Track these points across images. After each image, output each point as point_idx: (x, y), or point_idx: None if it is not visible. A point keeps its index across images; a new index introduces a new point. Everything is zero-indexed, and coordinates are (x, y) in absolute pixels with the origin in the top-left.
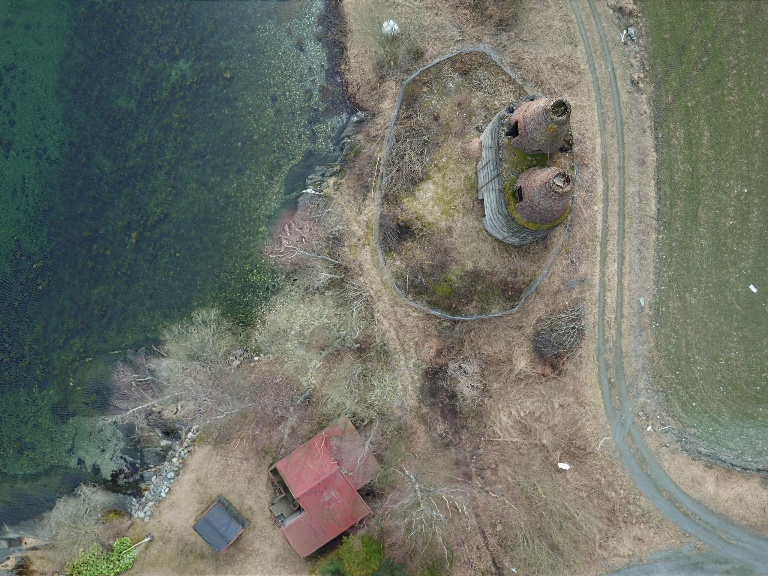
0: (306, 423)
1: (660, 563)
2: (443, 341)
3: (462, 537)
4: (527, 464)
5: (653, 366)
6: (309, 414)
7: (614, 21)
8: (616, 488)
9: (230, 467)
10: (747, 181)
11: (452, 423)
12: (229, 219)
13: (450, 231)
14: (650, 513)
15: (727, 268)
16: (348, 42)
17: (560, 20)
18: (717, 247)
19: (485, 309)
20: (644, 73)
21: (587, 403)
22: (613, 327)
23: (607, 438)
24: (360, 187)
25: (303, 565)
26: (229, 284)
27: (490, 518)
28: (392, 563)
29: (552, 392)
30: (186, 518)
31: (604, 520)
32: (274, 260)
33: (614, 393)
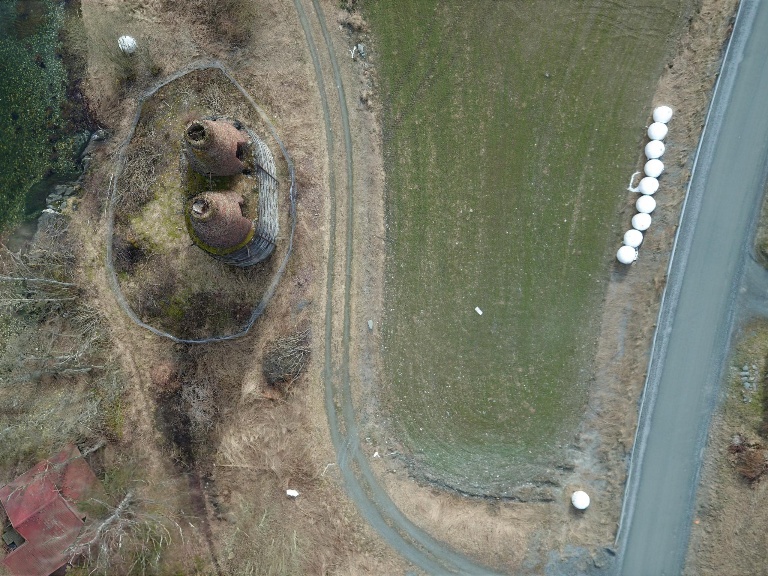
0: (40, 449)
1: None
2: (178, 364)
3: (195, 565)
4: (258, 491)
5: (381, 390)
6: (44, 440)
7: (344, 37)
8: (341, 515)
9: None
10: (472, 201)
11: (186, 448)
12: None
13: (176, 252)
14: (374, 541)
15: (453, 290)
16: (89, 58)
17: (290, 36)
18: (444, 268)
19: (217, 332)
20: (373, 90)
21: (312, 428)
22: (340, 350)
23: (332, 464)
24: (96, 207)
25: None
26: None
27: (222, 546)
28: None
29: (281, 417)
30: None
31: (331, 548)
32: None
33: (340, 418)
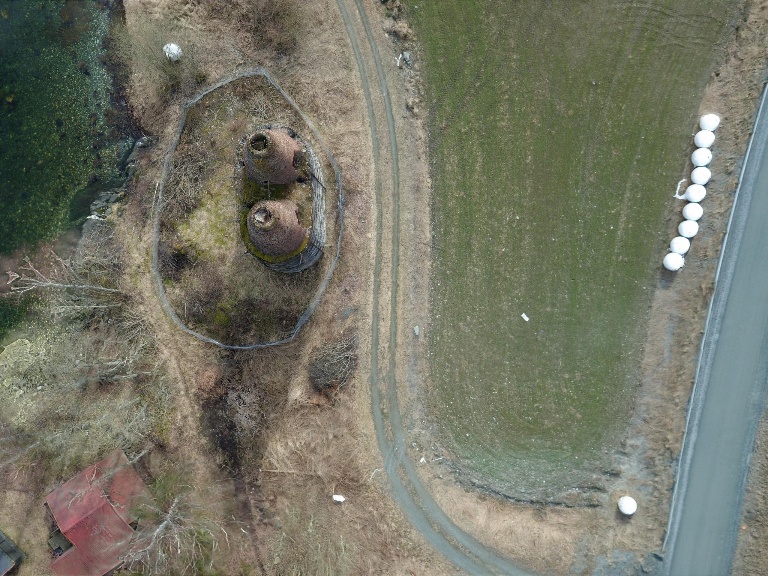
0: (86, 454)
1: None
2: (223, 370)
3: (240, 570)
4: (304, 496)
5: (427, 396)
6: (89, 445)
7: (389, 45)
8: (388, 521)
9: (8, 499)
10: (519, 208)
11: (232, 454)
12: (14, 246)
13: (223, 259)
14: (421, 546)
15: (500, 296)
16: (133, 65)
17: (336, 44)
18: (490, 275)
19: (263, 338)
20: (419, 98)
21: (359, 434)
22: (387, 356)
23: (379, 470)
24: (141, 213)
25: None
26: (14, 312)
27: (268, 551)
28: None
29: (327, 423)
30: None
31: (378, 553)
32: (1, 294)
33: (387, 424)
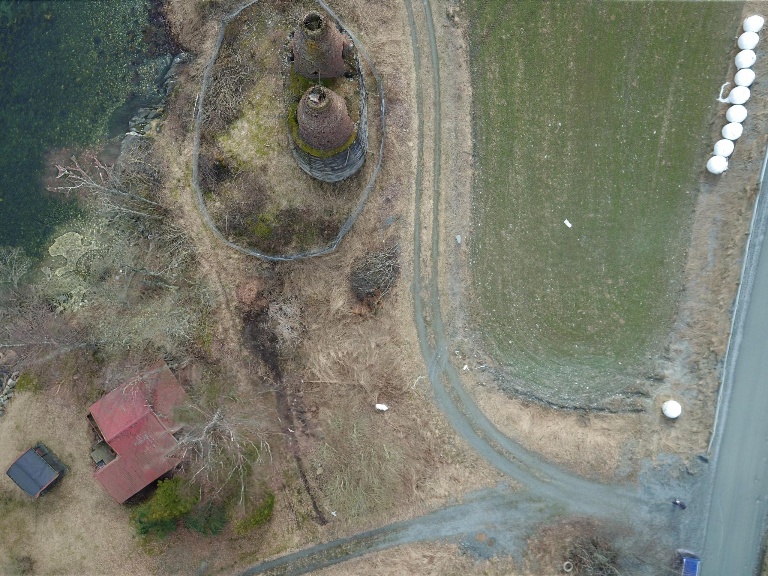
0: (127, 368)
1: (475, 503)
2: (264, 283)
3: (283, 481)
4: (346, 406)
5: (470, 304)
6: (130, 359)
7: None
8: (431, 428)
9: (50, 413)
10: (561, 114)
11: (273, 366)
12: (53, 163)
13: (264, 169)
14: (465, 452)
15: (542, 203)
16: None
17: None
18: (532, 182)
19: (304, 249)
20: (460, 6)
21: (402, 342)
22: (429, 265)
23: (422, 377)
24: (180, 128)
25: (123, 512)
26: (53, 229)
27: (311, 462)
28: (210, 508)
29: (369, 332)
30: (5, 466)
31: (421, 461)
32: (50, 188)
33: (430, 332)
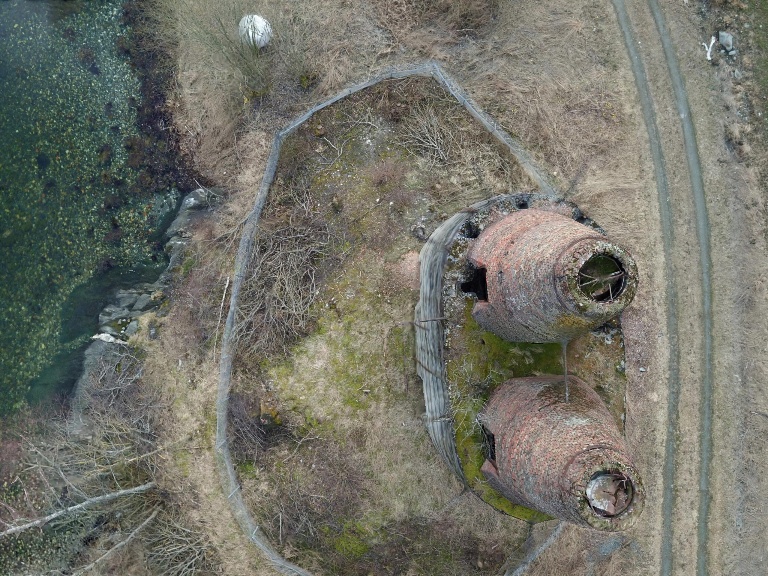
0: None
1: None
2: None
3: None
4: None
5: None
6: None
7: (691, 18)
8: None
9: None
10: None
11: None
12: None
13: (360, 438)
14: None
15: None
16: (180, 56)
17: (582, 16)
18: None
19: None
20: (752, 123)
21: None
22: None
23: None
24: (194, 335)
25: None
26: None
27: None
28: None
29: None
30: None
31: None
32: None
33: None
